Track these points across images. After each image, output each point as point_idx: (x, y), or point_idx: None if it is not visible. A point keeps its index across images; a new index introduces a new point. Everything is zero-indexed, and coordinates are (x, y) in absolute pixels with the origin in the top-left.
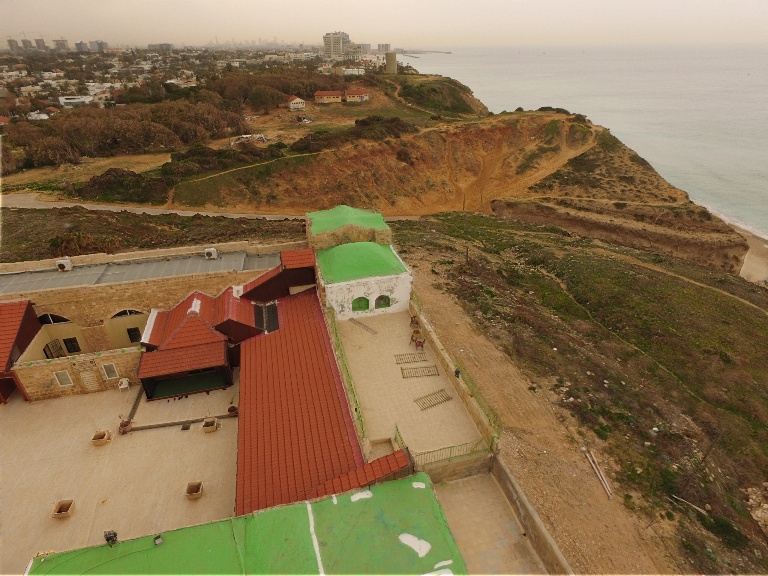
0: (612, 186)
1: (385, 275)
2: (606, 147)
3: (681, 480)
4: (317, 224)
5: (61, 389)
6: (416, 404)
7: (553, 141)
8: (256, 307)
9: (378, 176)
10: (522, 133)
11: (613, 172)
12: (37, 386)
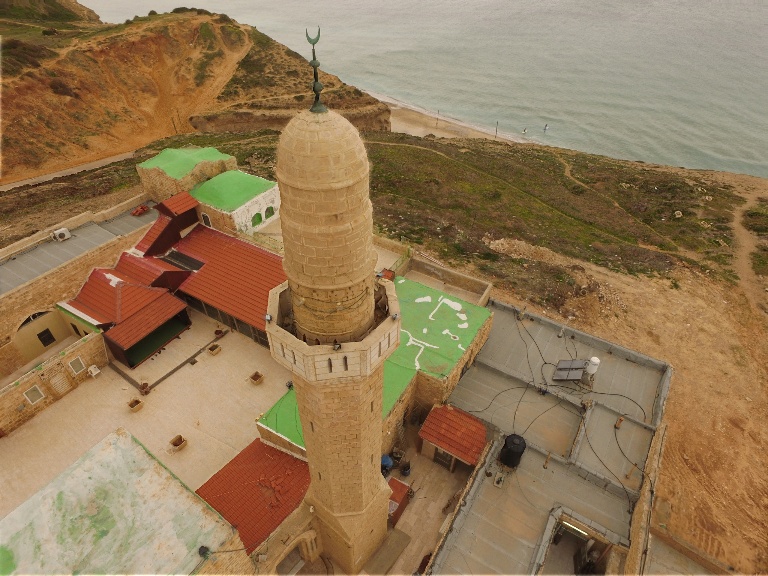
0: (285, 82)
1: (265, 191)
2: (263, 46)
3: (463, 245)
4: (169, 170)
5: (33, 407)
6: None
7: (214, 46)
8: (162, 259)
9: (47, 119)
10: (178, 41)
11: (279, 69)
12: (9, 416)
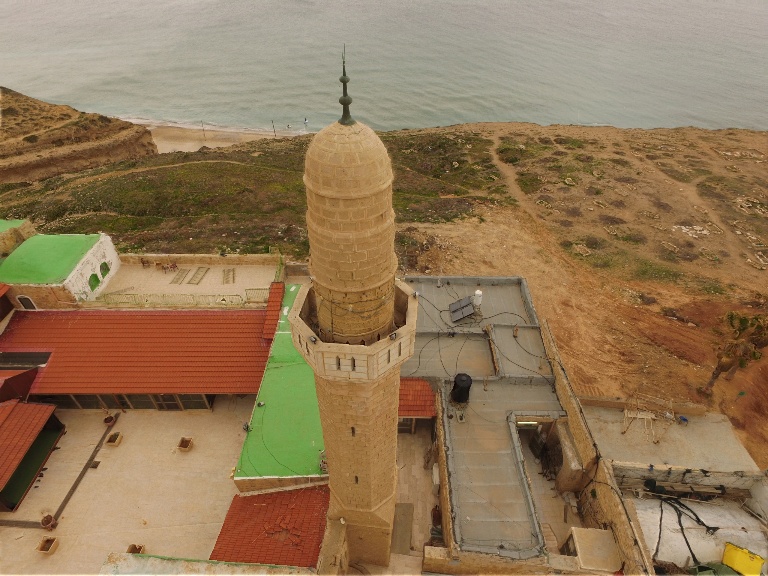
0: (2, 124)
1: (92, 246)
2: None
3: None
4: None
5: None
6: (226, 284)
7: None
8: None
9: None
10: None
11: None
12: None
